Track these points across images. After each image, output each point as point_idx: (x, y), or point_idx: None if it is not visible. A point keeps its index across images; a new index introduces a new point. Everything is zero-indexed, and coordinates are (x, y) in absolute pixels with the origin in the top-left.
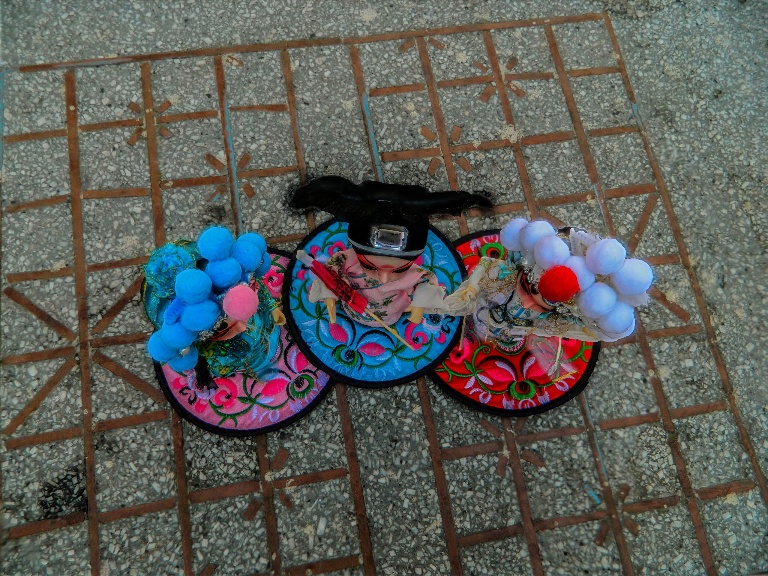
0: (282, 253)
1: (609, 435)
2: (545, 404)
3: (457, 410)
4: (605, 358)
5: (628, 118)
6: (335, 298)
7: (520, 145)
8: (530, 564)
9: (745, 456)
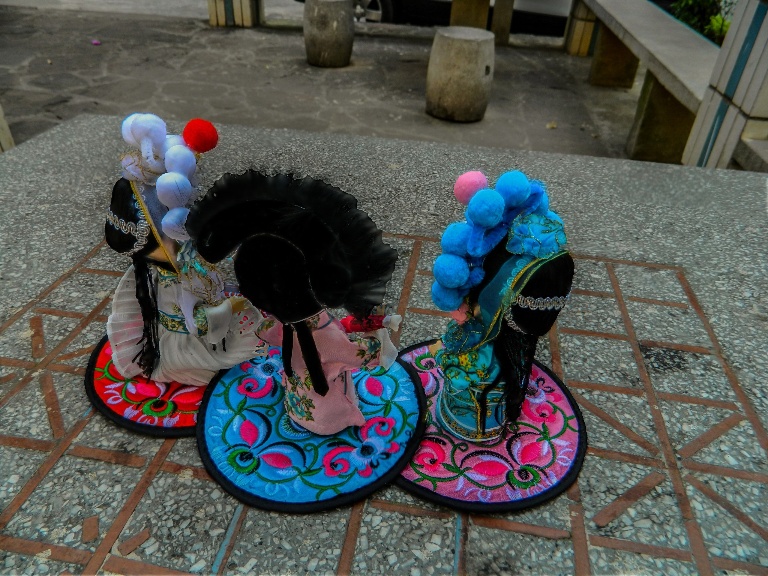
0: (410, 484)
1: None
2: None
3: None
4: None
5: None
6: None
7: None
8: None
9: (103, 248)
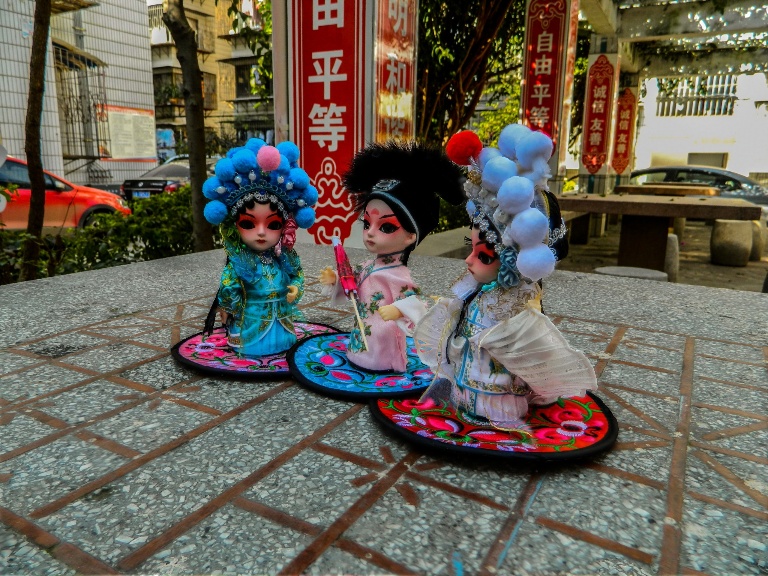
0: None
1: (543, 532)
2: (467, 446)
3: (368, 431)
4: (598, 479)
5: (760, 384)
6: (336, 275)
7: (609, 361)
8: (283, 566)
9: None
